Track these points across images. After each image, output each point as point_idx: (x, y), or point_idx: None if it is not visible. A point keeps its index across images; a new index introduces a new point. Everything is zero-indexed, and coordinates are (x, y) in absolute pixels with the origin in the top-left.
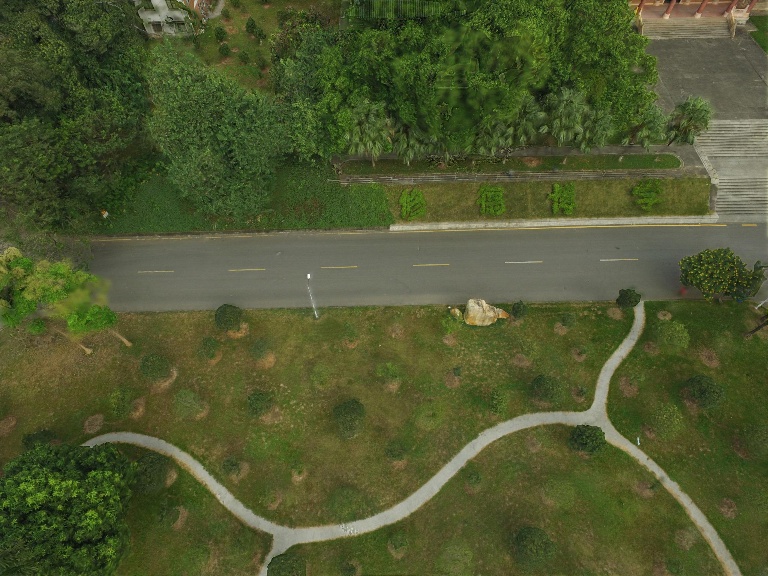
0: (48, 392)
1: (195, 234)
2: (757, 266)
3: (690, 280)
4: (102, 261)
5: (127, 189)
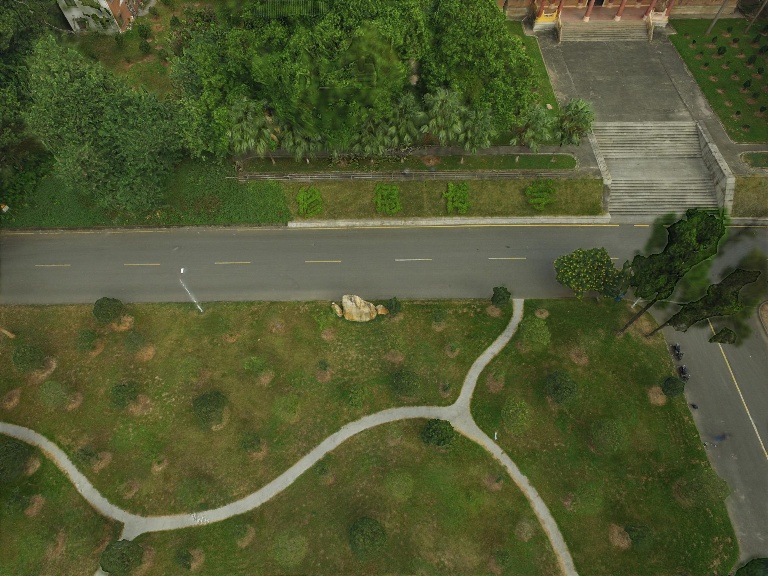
0: None
1: (97, 229)
2: (626, 265)
3: (561, 279)
4: (2, 254)
5: (27, 183)
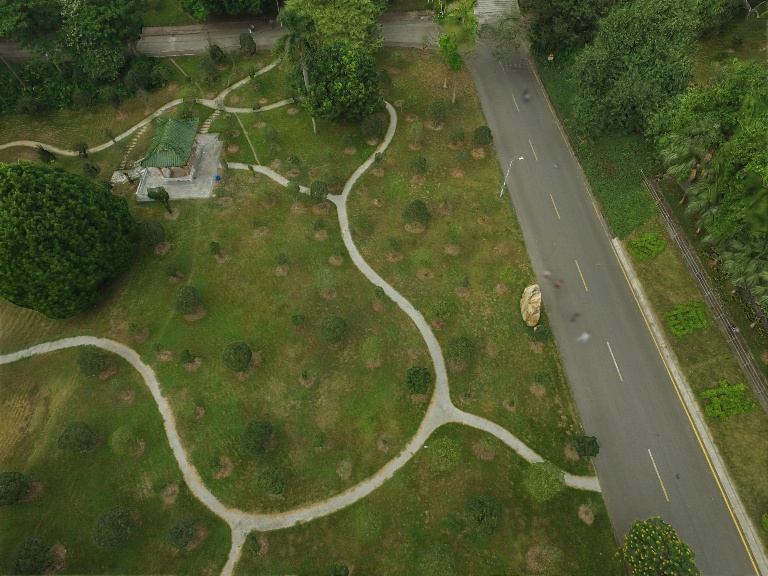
0: (417, 80)
1: (557, 115)
2: None
3: None
4: (516, 76)
5: None
